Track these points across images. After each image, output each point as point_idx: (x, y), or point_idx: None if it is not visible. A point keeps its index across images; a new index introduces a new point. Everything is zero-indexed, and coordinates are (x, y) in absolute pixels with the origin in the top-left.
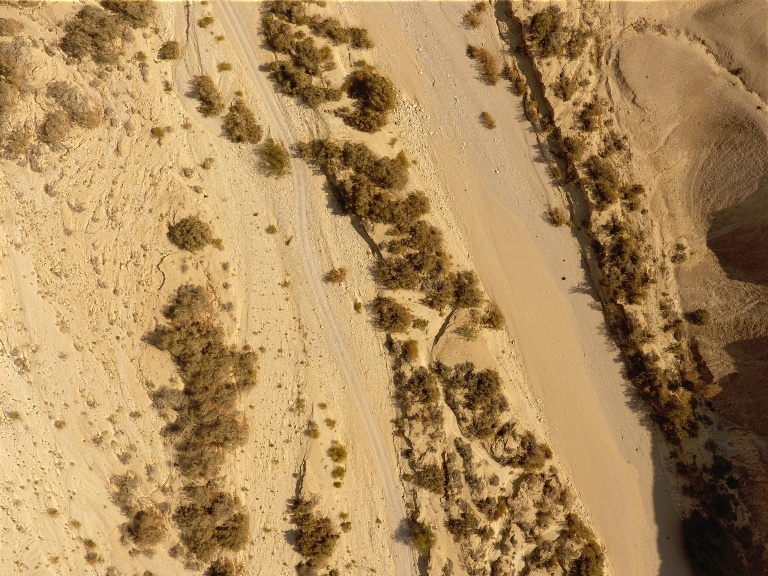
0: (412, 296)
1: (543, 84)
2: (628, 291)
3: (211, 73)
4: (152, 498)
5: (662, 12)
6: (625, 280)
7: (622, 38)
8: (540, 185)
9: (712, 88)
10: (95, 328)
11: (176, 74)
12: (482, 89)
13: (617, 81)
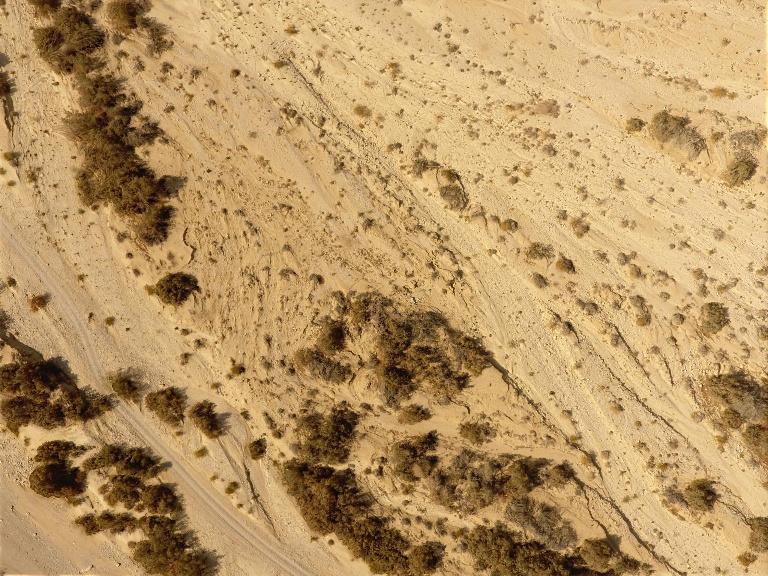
0: None
1: None
2: None
3: (211, 443)
4: (71, 46)
5: None
6: None
7: None
8: None
9: None
10: (233, 171)
11: (245, 430)
12: None
13: None
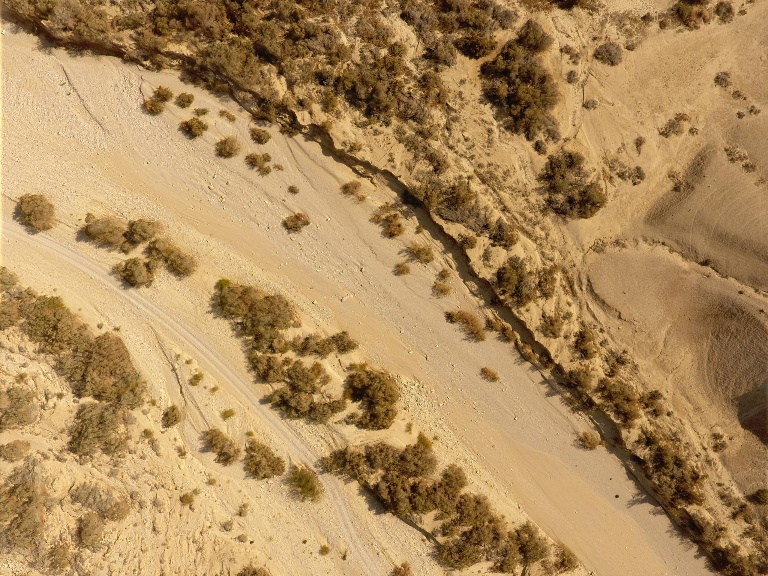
0: (480, 568)
1: (529, 330)
2: (685, 496)
3: (217, 425)
4: None
5: (614, 228)
6: (677, 484)
7: (586, 263)
8: (561, 417)
9: (689, 285)
10: None
11: (185, 435)
12: (473, 348)
13: (597, 303)
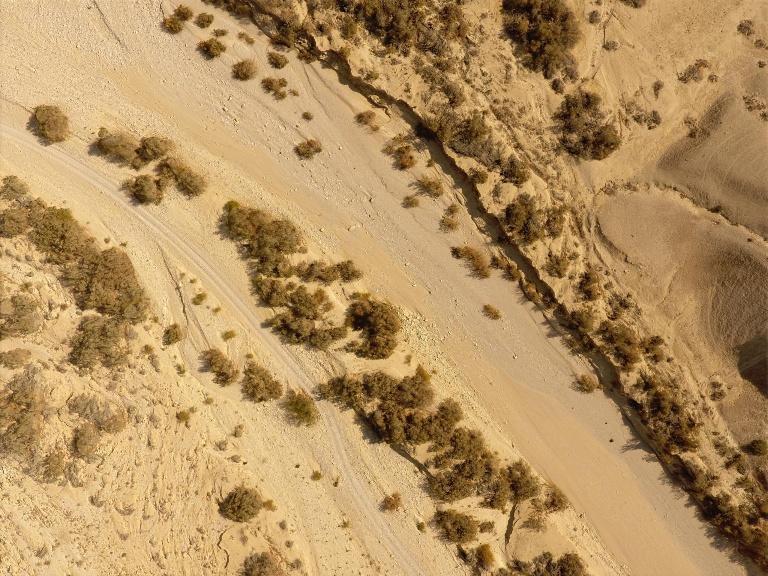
0: (471, 502)
1: (535, 268)
2: (679, 442)
3: (218, 345)
4: None
5: (626, 171)
6: (672, 431)
7: (596, 205)
8: (560, 358)
9: (698, 231)
10: None
11: (185, 354)
12: (477, 284)
13: (604, 245)
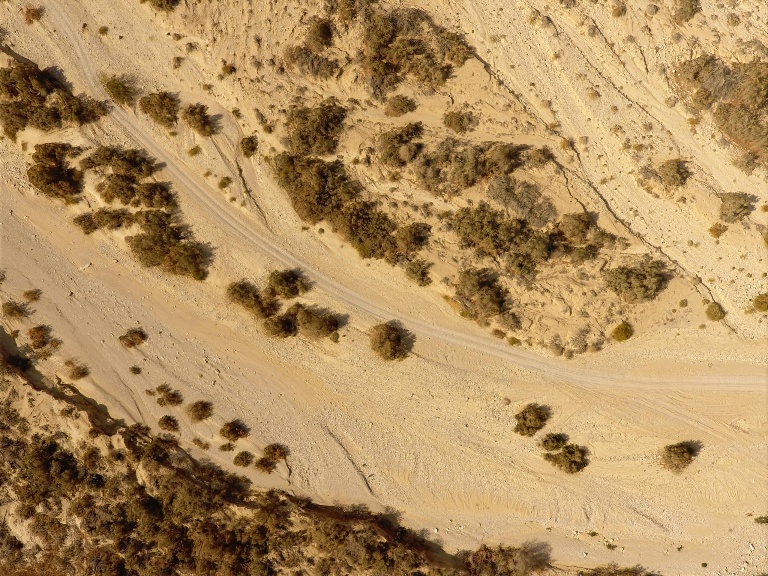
0: None
1: None
2: None
3: (204, 141)
4: None
5: None
6: None
7: None
8: None
9: None
10: None
11: (237, 130)
12: None
13: None
